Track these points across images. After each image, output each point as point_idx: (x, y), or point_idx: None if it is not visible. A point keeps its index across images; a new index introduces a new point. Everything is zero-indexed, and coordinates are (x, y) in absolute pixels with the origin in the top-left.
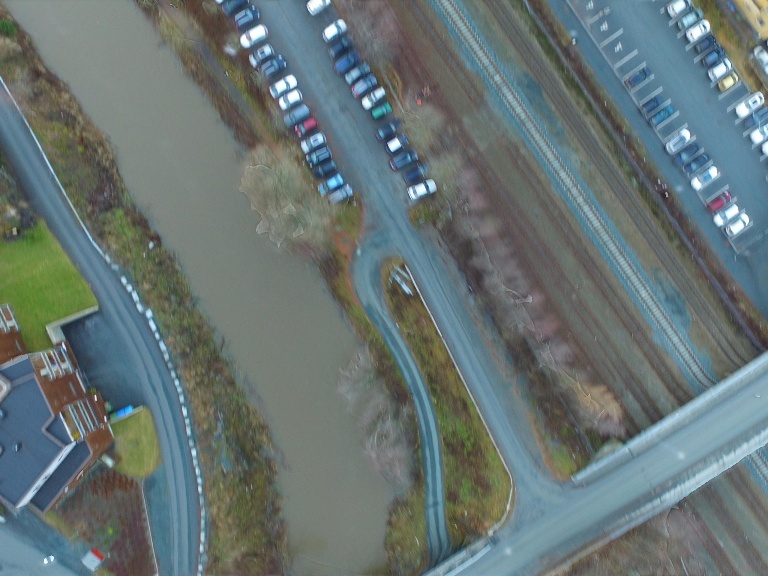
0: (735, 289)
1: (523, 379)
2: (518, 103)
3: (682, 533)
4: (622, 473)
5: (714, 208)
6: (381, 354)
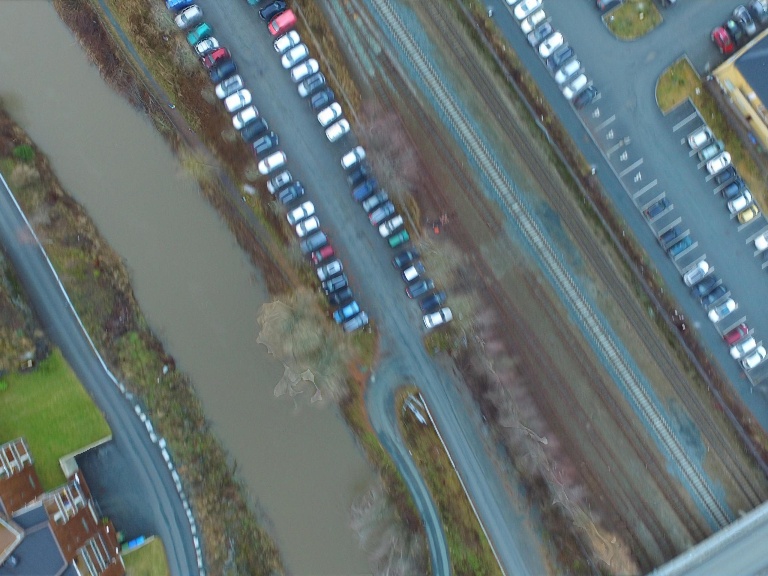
0: (750, 421)
1: (536, 511)
2: (536, 232)
3: None
4: None
5: (731, 341)
6: (393, 480)
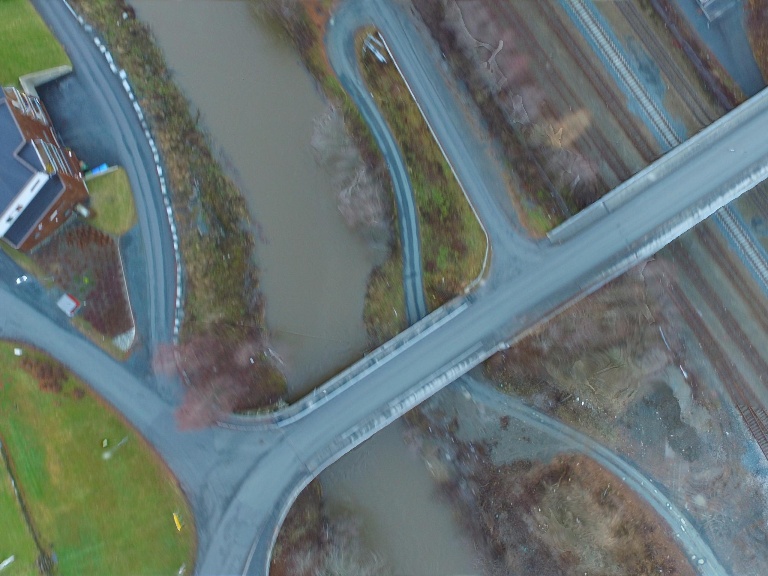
0: (709, 57)
1: (498, 143)
2: None
3: (660, 303)
4: (598, 229)
5: None
6: (356, 125)
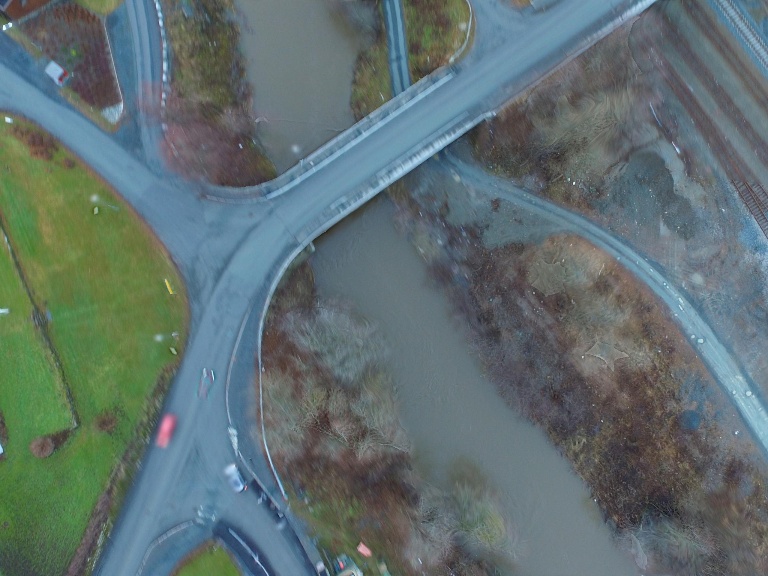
0: None
1: None
2: None
3: (650, 79)
4: None
5: None
6: None
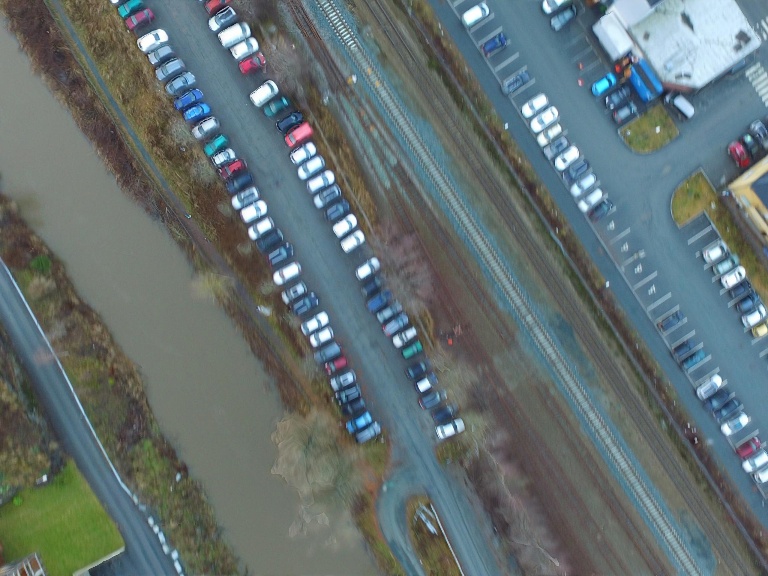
0: (762, 534)
1: None
2: (549, 344)
3: None
4: None
5: (743, 455)
6: None
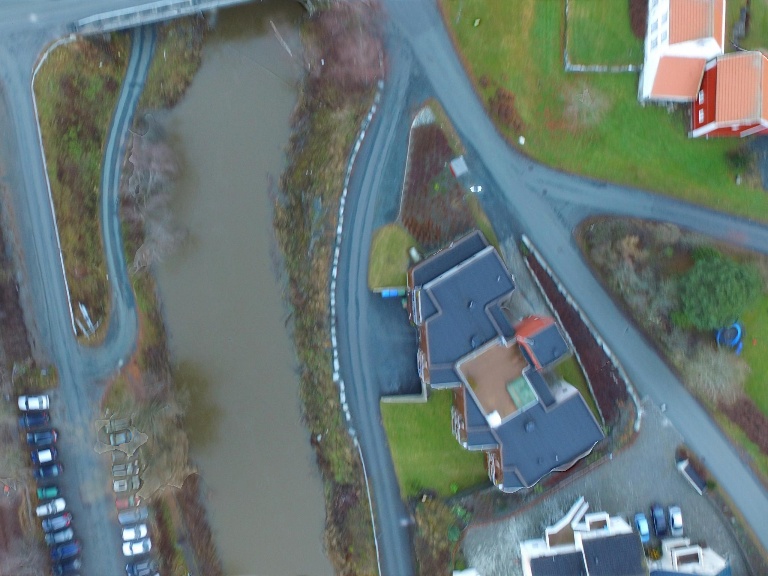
0: None
1: None
2: None
3: None
4: None
5: None
6: None
